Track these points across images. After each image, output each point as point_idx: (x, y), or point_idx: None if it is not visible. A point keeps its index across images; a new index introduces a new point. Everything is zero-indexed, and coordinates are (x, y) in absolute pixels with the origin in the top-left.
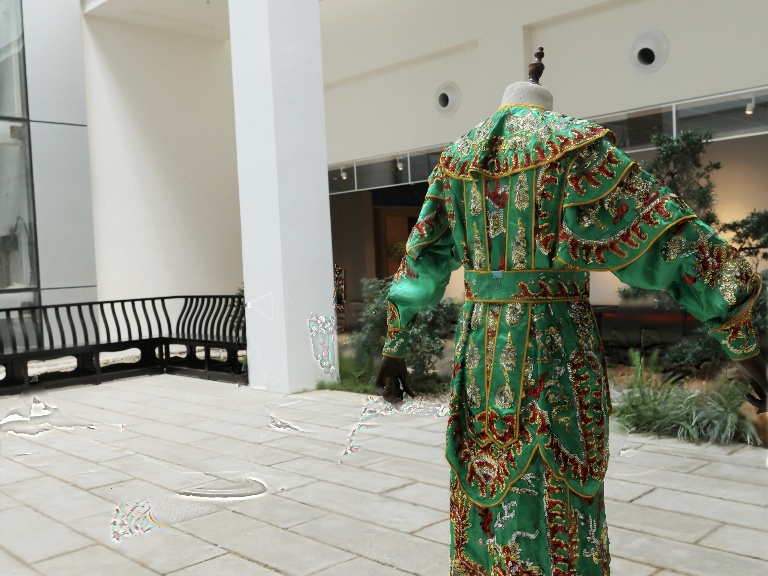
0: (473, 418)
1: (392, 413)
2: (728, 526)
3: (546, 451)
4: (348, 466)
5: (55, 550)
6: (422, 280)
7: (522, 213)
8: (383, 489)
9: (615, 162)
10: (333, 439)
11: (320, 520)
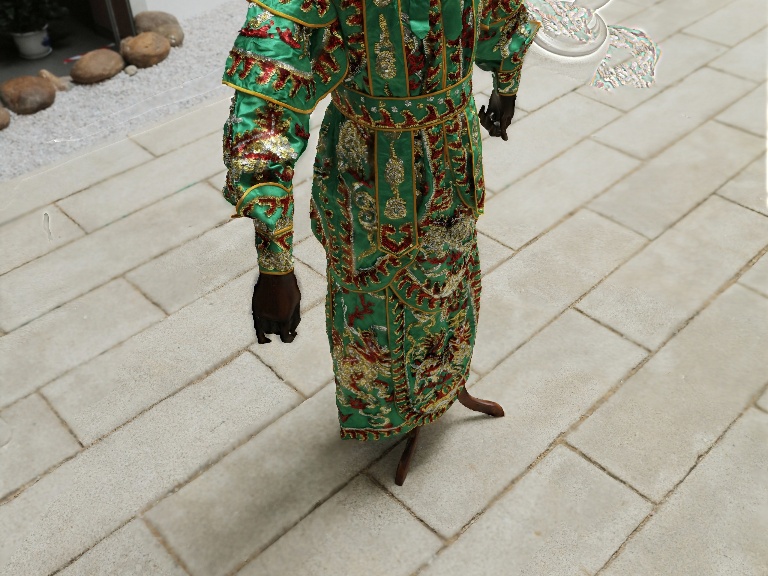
0: None
1: None
2: None
3: None
4: None
5: (748, 123)
6: None
7: None
8: None
9: None
10: None
11: None
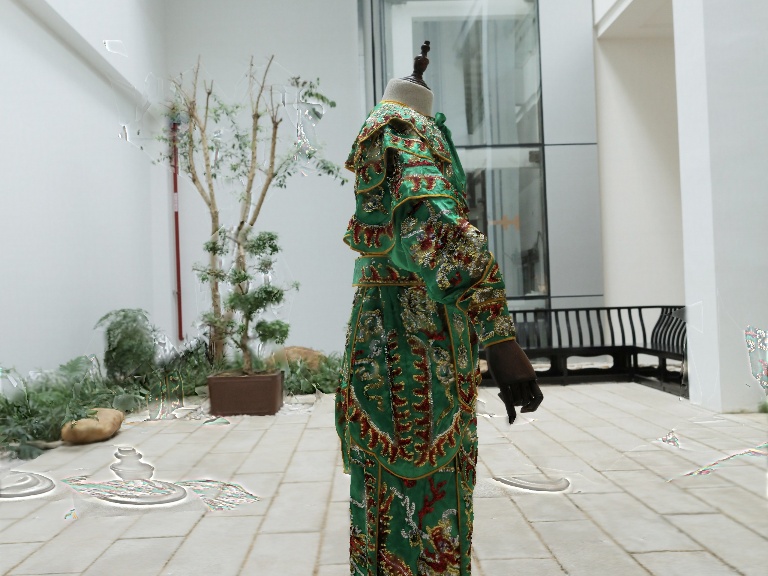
0: None
1: None
2: None
3: (350, 423)
4: (672, 485)
5: None
6: None
7: (357, 203)
8: (671, 511)
9: None
10: (698, 459)
11: (567, 522)
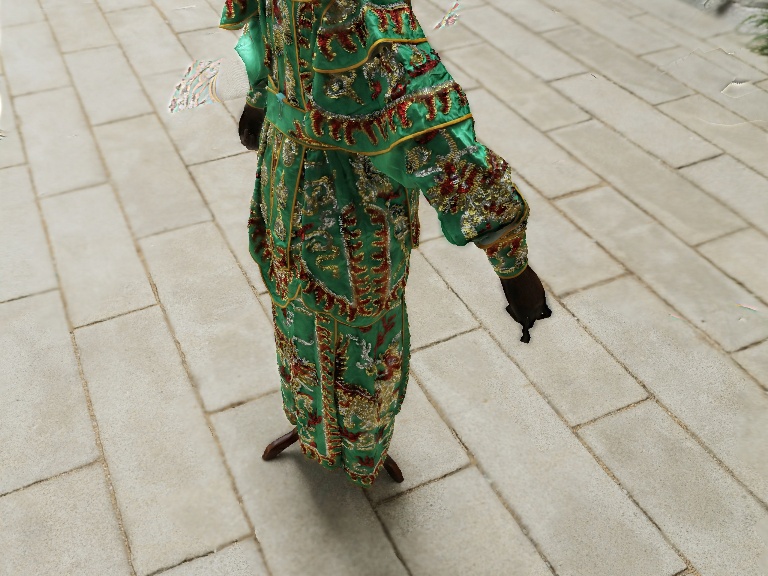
0: None
1: None
2: (751, 231)
3: (304, 294)
4: None
5: (117, 113)
6: (255, 49)
7: (288, 48)
8: None
9: (364, 31)
10: None
11: None
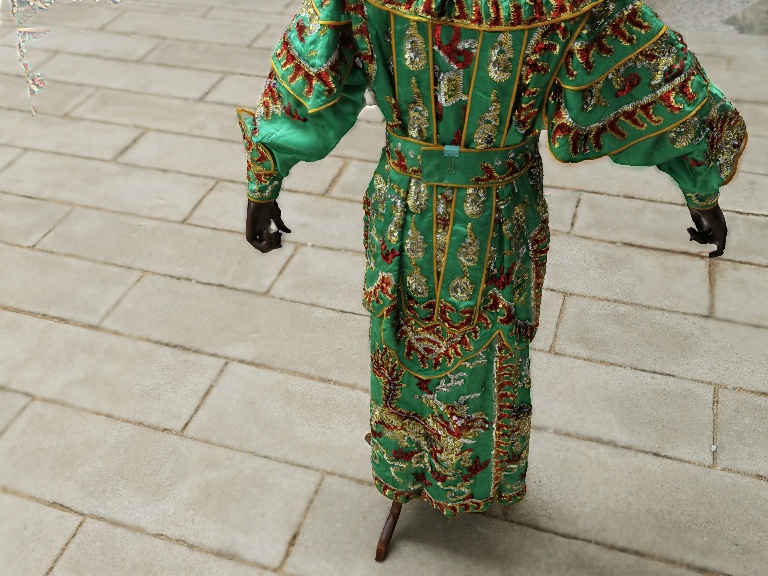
0: (415, 304)
1: (52, 3)
2: None
3: (510, 338)
4: (48, 117)
5: None
6: (313, 126)
7: (499, 85)
8: (114, 152)
9: (640, 26)
10: (0, 67)
11: (67, 223)
